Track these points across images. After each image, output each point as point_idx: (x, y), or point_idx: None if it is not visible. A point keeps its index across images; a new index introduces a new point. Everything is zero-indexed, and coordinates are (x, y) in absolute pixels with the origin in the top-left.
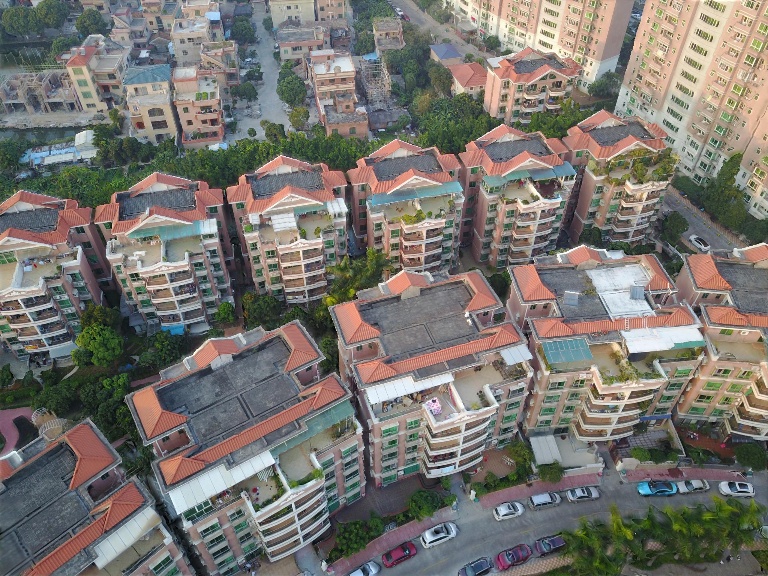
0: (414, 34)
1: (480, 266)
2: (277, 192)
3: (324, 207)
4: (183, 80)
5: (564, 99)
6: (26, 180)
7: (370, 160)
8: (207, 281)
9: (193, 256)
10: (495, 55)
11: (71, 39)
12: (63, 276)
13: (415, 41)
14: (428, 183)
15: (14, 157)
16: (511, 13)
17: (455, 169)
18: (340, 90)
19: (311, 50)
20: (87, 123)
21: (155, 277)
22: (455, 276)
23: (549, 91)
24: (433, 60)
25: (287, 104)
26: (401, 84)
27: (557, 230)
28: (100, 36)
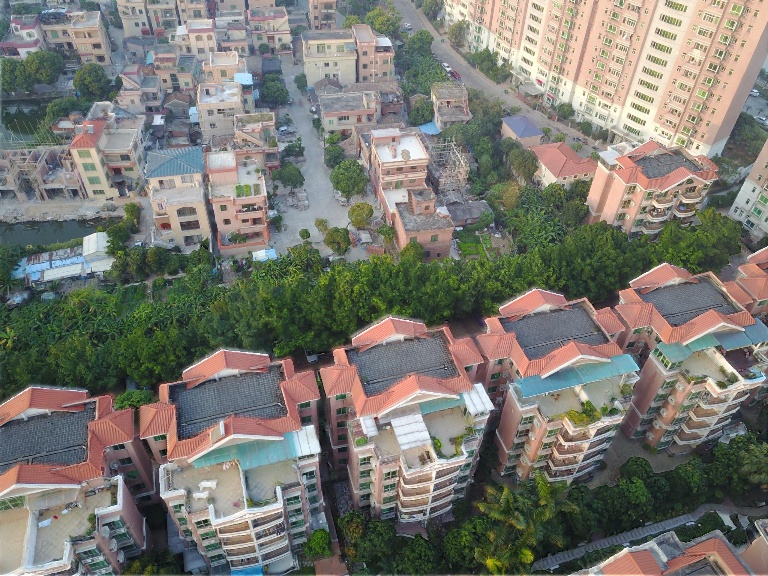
0: (482, 104)
1: (633, 444)
2: (392, 377)
3: (461, 402)
4: (220, 171)
5: (696, 205)
6: (21, 308)
7: (505, 319)
8: (300, 513)
9: (287, 489)
10: (569, 126)
11: (68, 100)
12: (98, 533)
13: (483, 112)
14: (594, 360)
15: (5, 275)
16: (592, 81)
17: (618, 332)
18: (409, 179)
19: (361, 121)
20: (94, 215)
21: (233, 525)
22: (690, 545)
23: (682, 197)
24: (511, 139)
25: (340, 192)
26: (473, 166)
27: (740, 404)
28: (108, 104)
